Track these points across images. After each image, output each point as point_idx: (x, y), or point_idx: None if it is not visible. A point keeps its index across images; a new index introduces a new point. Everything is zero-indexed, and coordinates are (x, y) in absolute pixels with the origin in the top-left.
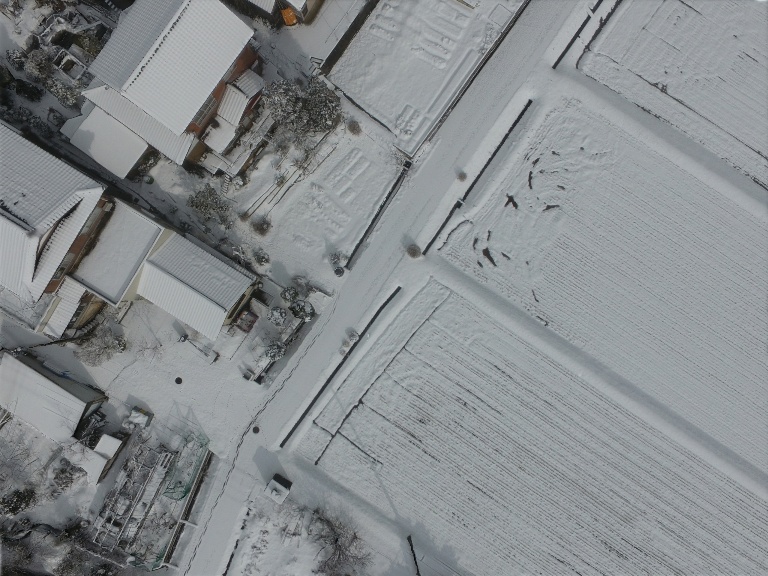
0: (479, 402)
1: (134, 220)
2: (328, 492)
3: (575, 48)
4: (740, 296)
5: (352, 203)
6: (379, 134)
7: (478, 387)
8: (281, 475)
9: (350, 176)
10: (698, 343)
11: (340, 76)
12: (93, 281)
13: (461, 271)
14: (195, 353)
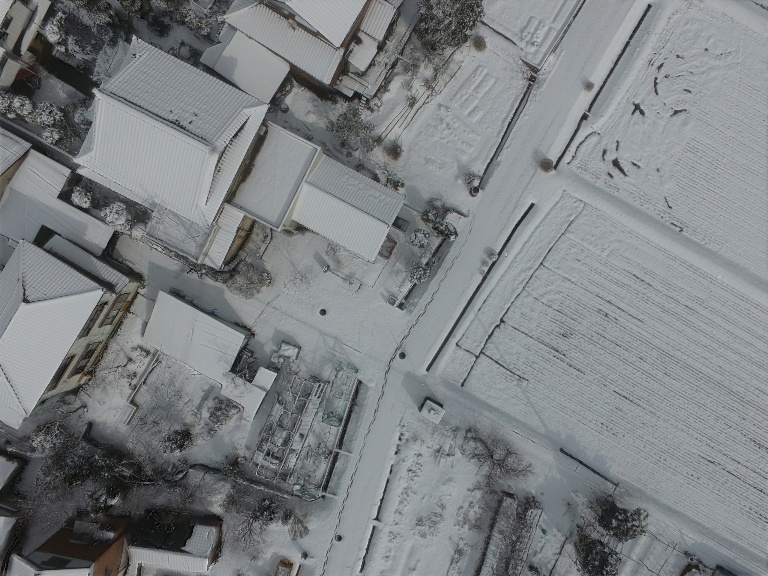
0: (620, 312)
1: (288, 142)
2: (478, 411)
3: None
4: None
5: (481, 122)
6: (505, 48)
7: (618, 297)
8: (431, 398)
9: (477, 94)
10: None
11: None
12: (252, 207)
13: (592, 183)
14: (337, 283)
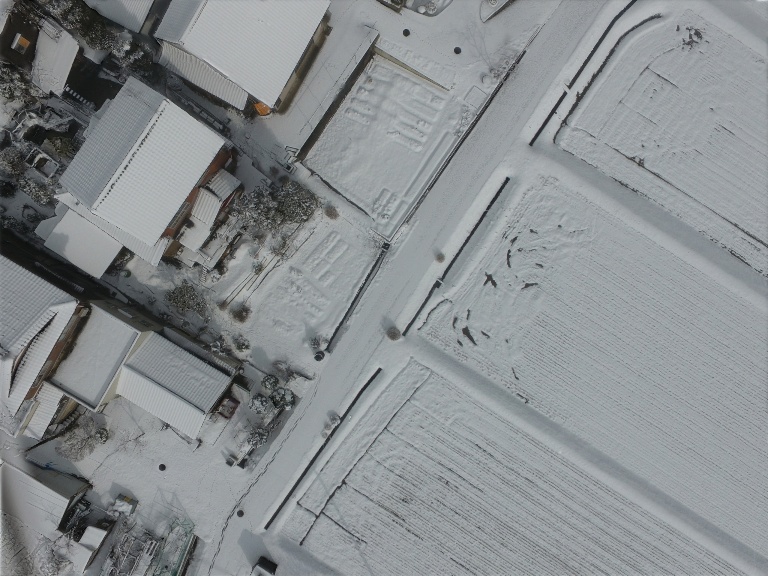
0: (461, 481)
1: (111, 324)
2: (313, 573)
3: (552, 124)
4: (717, 371)
5: (331, 286)
6: (356, 218)
7: (460, 466)
8: (266, 558)
9: (329, 259)
10: (676, 418)
11: (316, 160)
12: (71, 385)
13: (441, 350)
14: (178, 440)
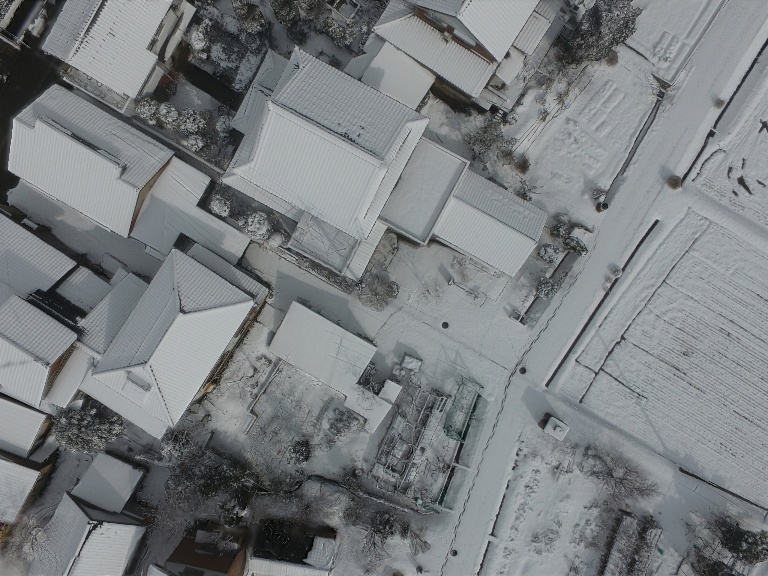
0: (743, 331)
1: (436, 156)
2: (598, 428)
3: None
4: None
5: (608, 137)
6: (637, 63)
7: (741, 316)
8: (551, 414)
9: (605, 109)
10: None
11: None
12: (397, 220)
13: (717, 201)
14: (460, 297)
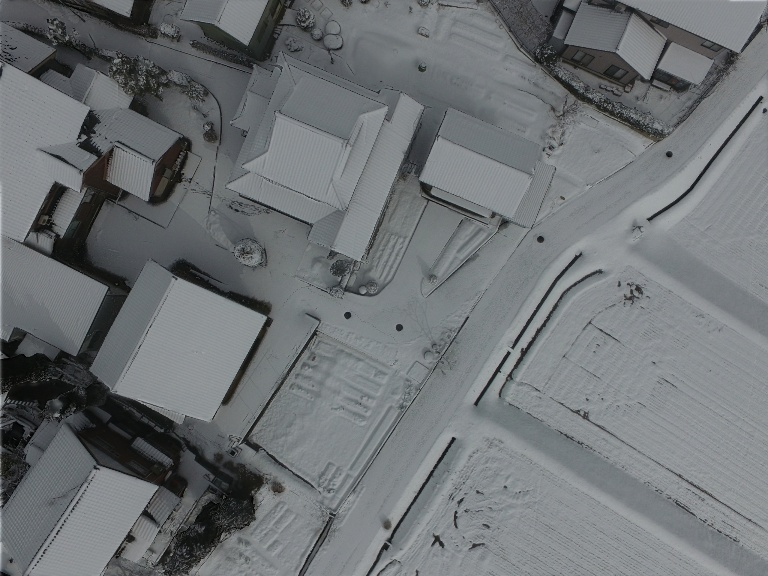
0: None
1: None
2: None
3: (497, 382)
4: None
5: (279, 556)
6: (303, 492)
7: None
8: None
9: (276, 529)
10: None
11: (262, 436)
12: None
13: None
14: None
